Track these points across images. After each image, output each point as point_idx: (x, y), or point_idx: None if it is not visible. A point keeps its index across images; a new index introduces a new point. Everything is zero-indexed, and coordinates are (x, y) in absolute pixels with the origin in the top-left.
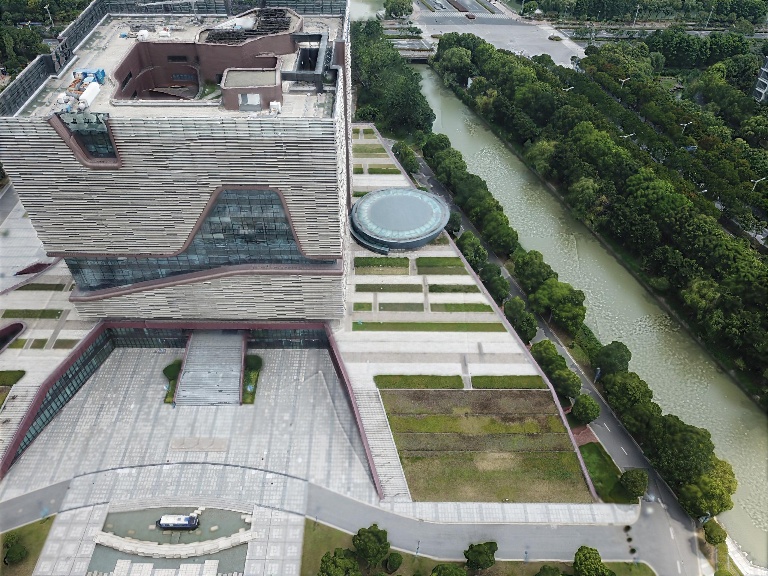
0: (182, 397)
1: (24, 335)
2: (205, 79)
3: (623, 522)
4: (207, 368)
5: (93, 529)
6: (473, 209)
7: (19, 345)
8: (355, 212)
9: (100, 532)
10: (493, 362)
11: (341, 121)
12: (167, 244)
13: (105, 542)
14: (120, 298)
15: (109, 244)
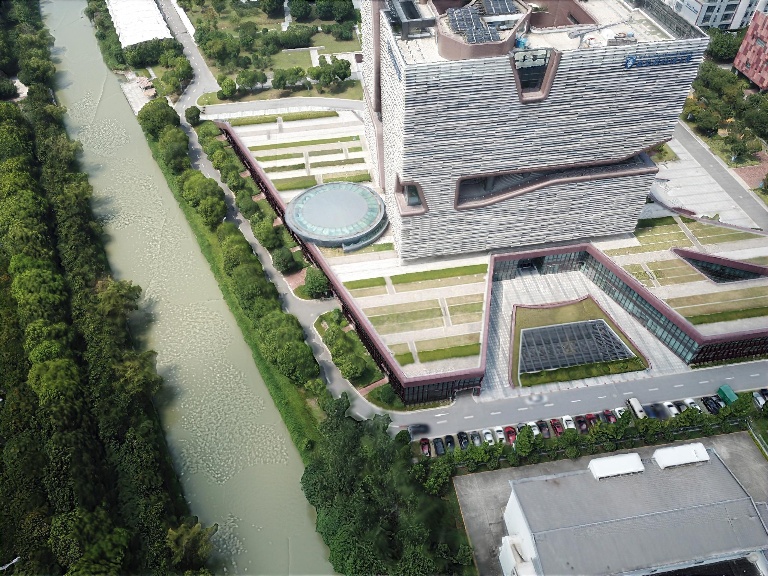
0: None
1: None
2: None
3: (204, 115)
4: None
5: None
6: (258, 262)
7: None
8: (381, 205)
9: None
10: (261, 131)
11: (366, 6)
12: None
13: None
14: None
15: None
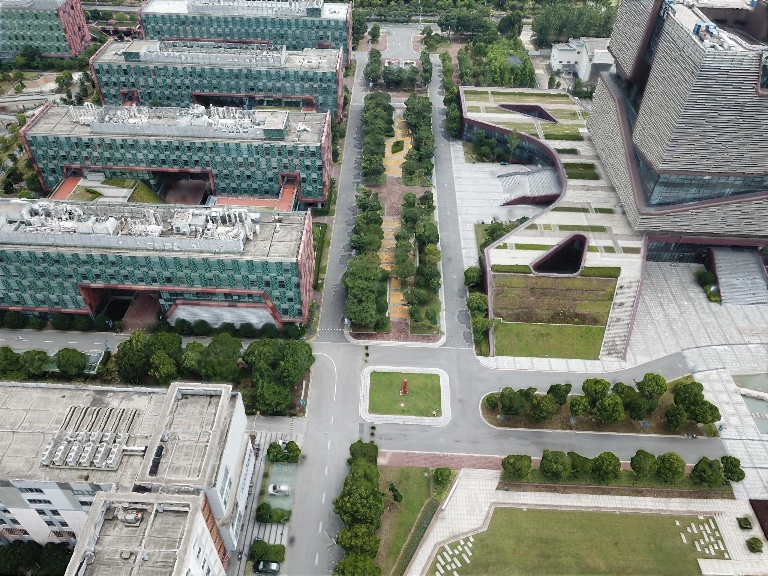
0: (724, 297)
1: (591, 243)
2: (763, 37)
3: None
4: (734, 276)
5: (730, 385)
6: None
7: (594, 250)
8: None
9: (738, 387)
10: None
11: None
12: (764, 165)
13: (751, 393)
14: (685, 213)
15: (717, 163)
